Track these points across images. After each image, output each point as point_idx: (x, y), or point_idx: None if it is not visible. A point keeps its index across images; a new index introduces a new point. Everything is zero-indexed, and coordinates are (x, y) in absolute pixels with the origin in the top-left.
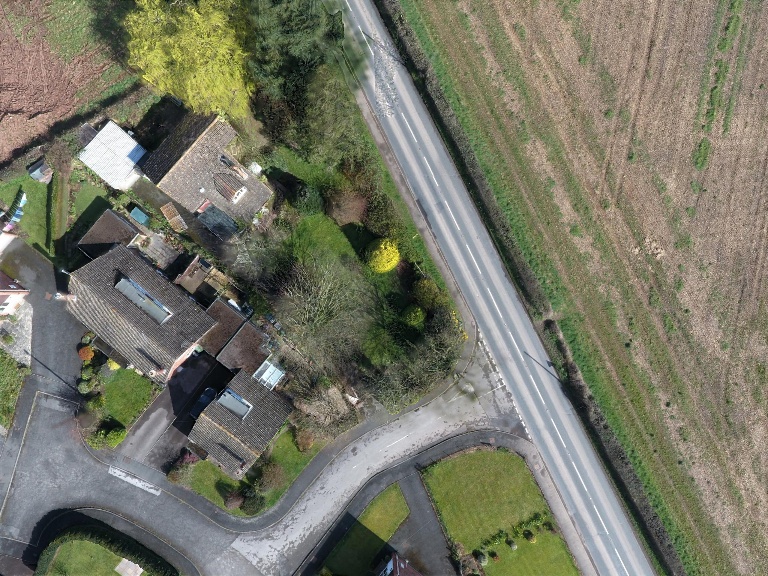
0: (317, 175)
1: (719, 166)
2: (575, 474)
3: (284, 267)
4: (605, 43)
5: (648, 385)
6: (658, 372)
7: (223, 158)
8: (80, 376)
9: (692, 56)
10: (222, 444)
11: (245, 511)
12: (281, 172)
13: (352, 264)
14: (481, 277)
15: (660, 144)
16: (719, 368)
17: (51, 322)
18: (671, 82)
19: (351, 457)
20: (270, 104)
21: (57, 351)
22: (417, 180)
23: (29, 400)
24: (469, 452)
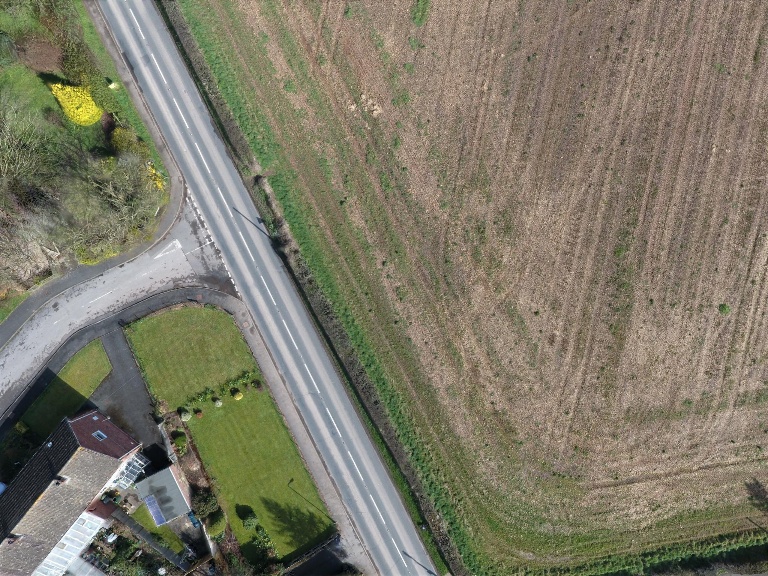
0: (19, 27)
1: (438, 22)
2: (285, 332)
3: None
4: None
5: (363, 244)
6: (374, 231)
7: None
8: None
9: None
10: None
11: None
12: None
13: (55, 118)
14: (189, 132)
15: None
16: (438, 227)
17: None
18: None
19: (52, 312)
20: None
21: None
22: (123, 32)
23: None
24: (175, 309)
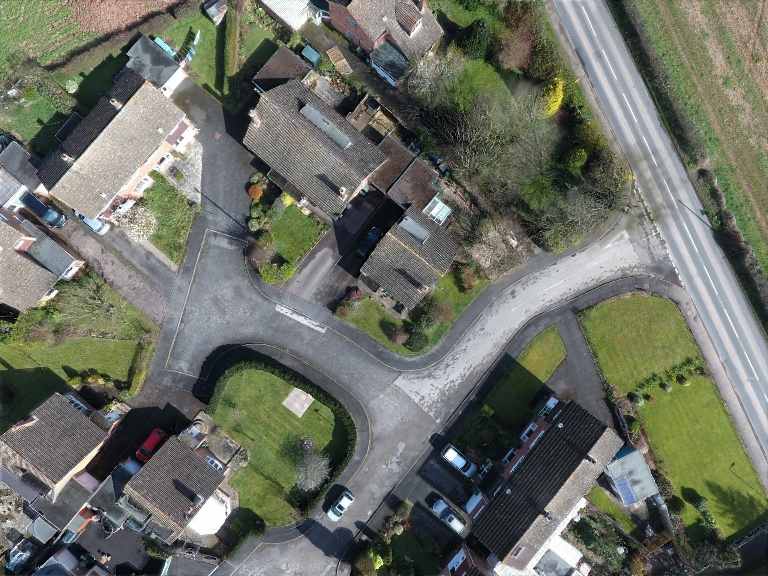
0: None
1: None
2: (727, 321)
3: (447, 111)
4: None
5: None
6: None
7: None
8: (249, 214)
9: None
10: (401, 269)
11: (411, 347)
12: (445, 17)
13: (511, 111)
14: (637, 126)
15: None
16: None
17: (220, 161)
18: None
19: (510, 300)
20: None
21: (226, 190)
22: (575, 29)
23: (199, 237)
24: (624, 297)
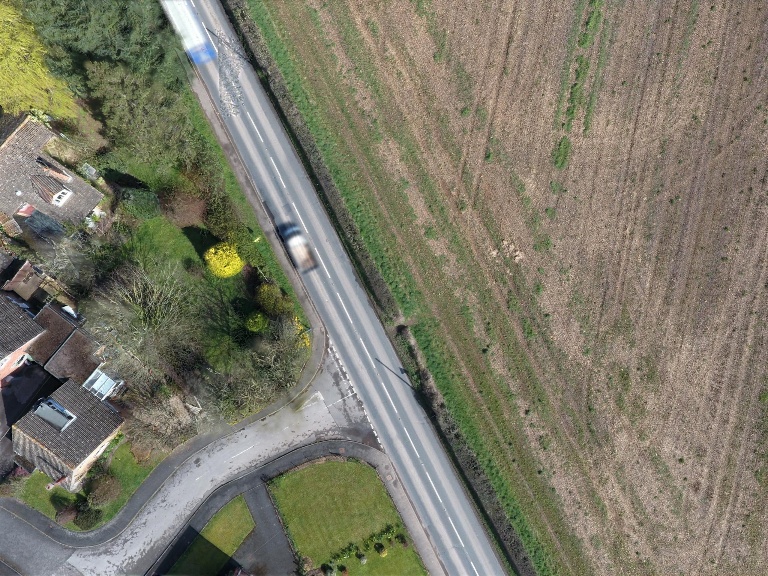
0: (159, 177)
1: (580, 165)
2: (429, 485)
3: (123, 272)
4: (461, 39)
5: (506, 392)
6: (517, 379)
7: (40, 160)
8: None
9: (552, 52)
10: (41, 457)
11: (79, 526)
12: (119, 174)
13: (196, 269)
14: (330, 281)
15: (518, 143)
16: (581, 374)
17: None
18: (530, 79)
19: (194, 469)
20: (109, 103)
21: None
22: (263, 181)
23: None
24: (318, 463)
